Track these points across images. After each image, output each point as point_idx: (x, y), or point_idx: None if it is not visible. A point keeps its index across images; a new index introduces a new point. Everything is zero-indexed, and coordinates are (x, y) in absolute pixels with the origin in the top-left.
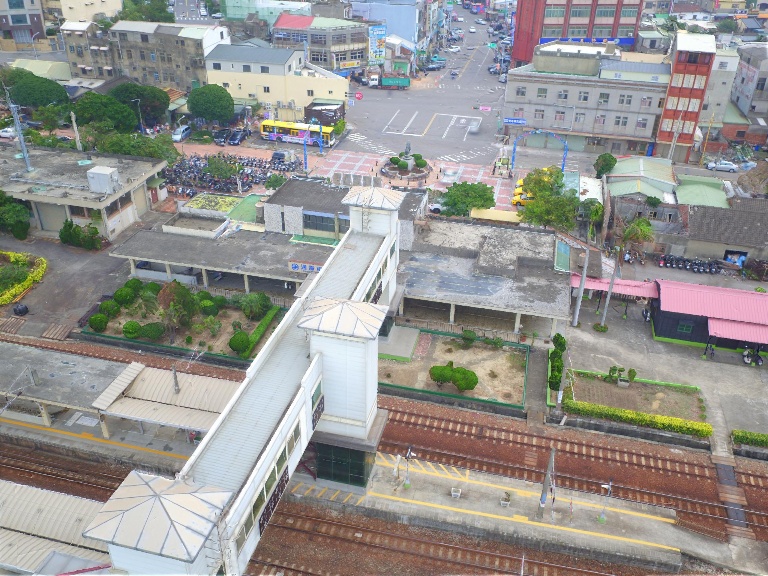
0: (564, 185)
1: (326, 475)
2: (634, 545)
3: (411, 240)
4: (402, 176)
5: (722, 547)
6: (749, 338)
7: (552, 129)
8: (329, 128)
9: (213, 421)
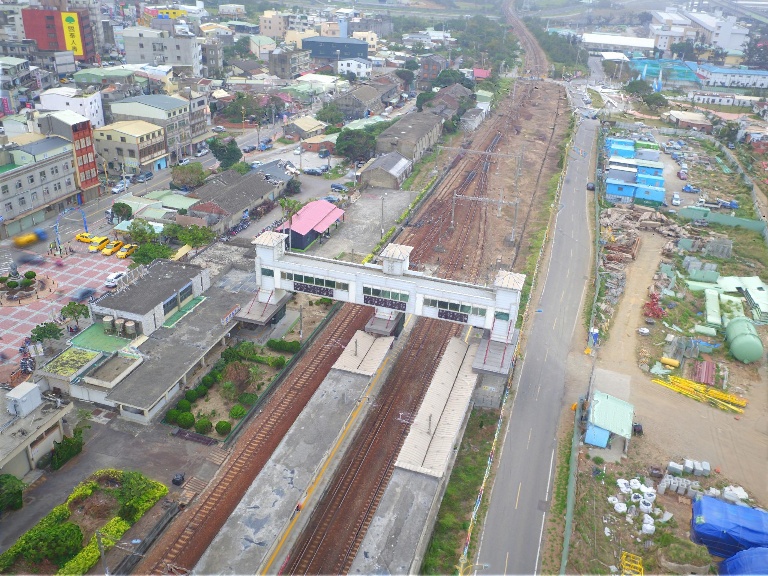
0: (152, 226)
1: (398, 333)
2: None
3: (209, 280)
4: (34, 290)
5: (427, 269)
6: (327, 227)
7: (21, 214)
8: None
9: (384, 342)
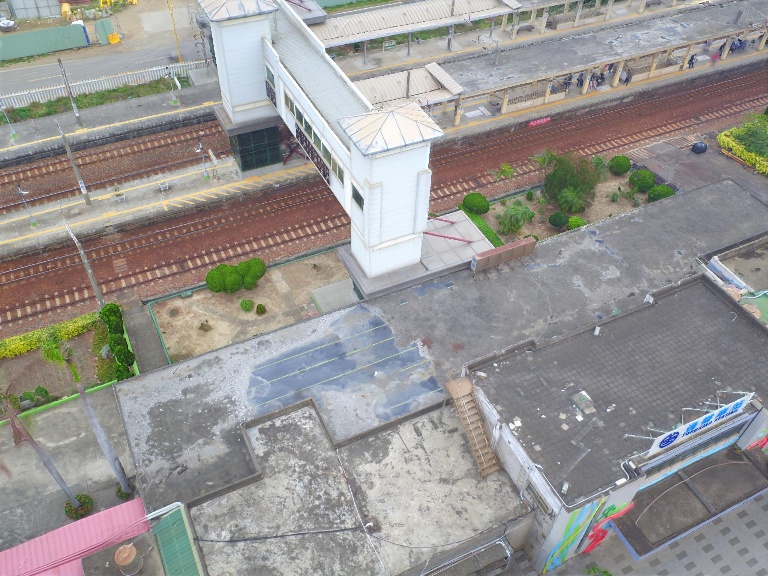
0: None
1: None
2: (4, 219)
3: None
4: None
5: None
6: None
7: None
8: None
9: None
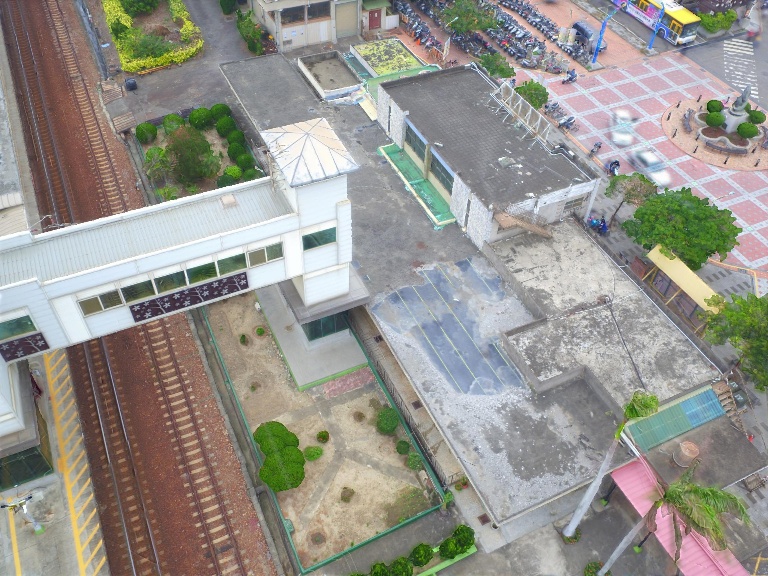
0: None
1: None
2: None
3: (484, 237)
4: (702, 135)
5: None
6: None
7: None
8: (692, 17)
9: None
